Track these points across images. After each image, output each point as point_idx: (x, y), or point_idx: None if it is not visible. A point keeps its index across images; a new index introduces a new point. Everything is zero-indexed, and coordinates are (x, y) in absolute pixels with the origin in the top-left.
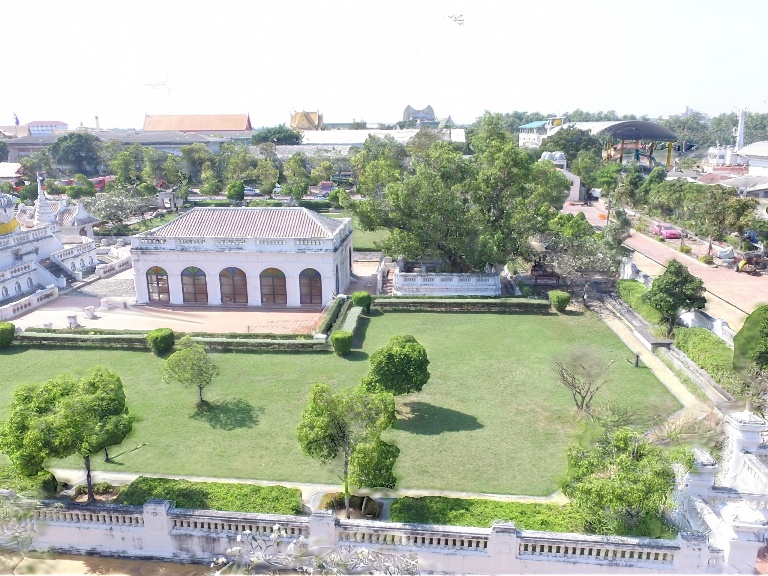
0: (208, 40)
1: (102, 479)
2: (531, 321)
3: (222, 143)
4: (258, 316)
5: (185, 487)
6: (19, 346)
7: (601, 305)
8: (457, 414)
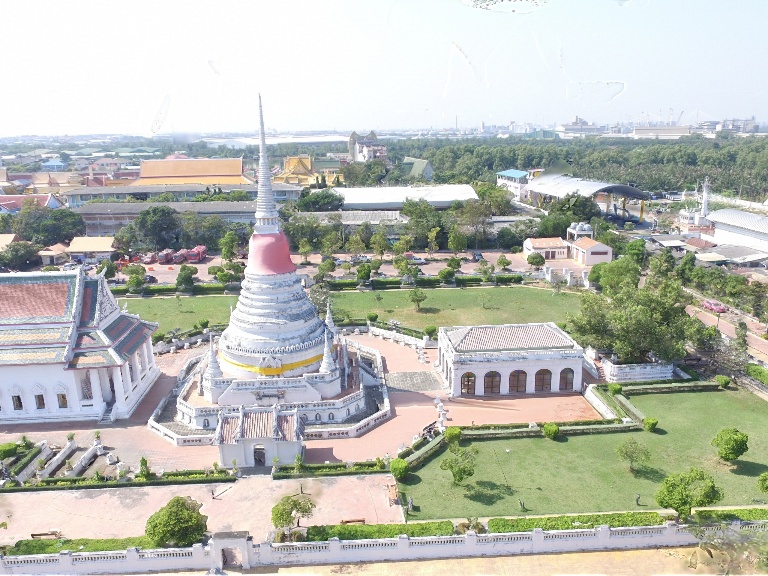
0: (210, 94)
1: (661, 513)
2: (717, 397)
3: (280, 209)
4: (544, 401)
5: (722, 513)
6: (462, 440)
7: (741, 381)
8: (755, 464)
